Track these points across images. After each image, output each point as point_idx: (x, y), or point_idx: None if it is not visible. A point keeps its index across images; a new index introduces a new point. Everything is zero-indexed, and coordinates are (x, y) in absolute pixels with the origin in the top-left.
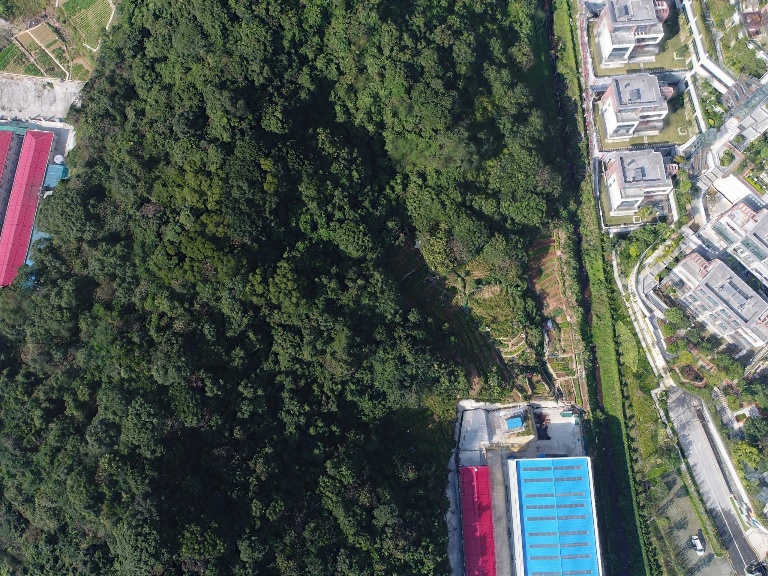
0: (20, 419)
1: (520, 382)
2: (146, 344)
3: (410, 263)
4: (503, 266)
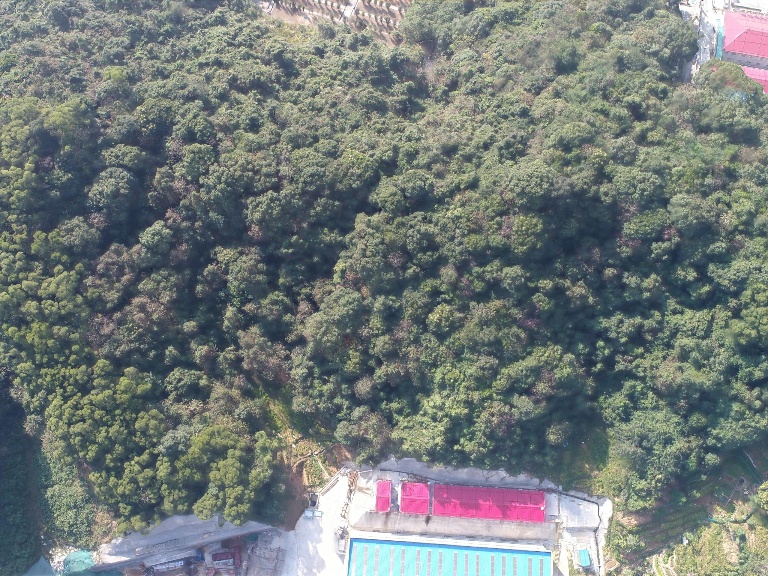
0: (629, 85)
1: (628, 570)
2: (704, 189)
3: (764, 463)
4: (767, 568)
